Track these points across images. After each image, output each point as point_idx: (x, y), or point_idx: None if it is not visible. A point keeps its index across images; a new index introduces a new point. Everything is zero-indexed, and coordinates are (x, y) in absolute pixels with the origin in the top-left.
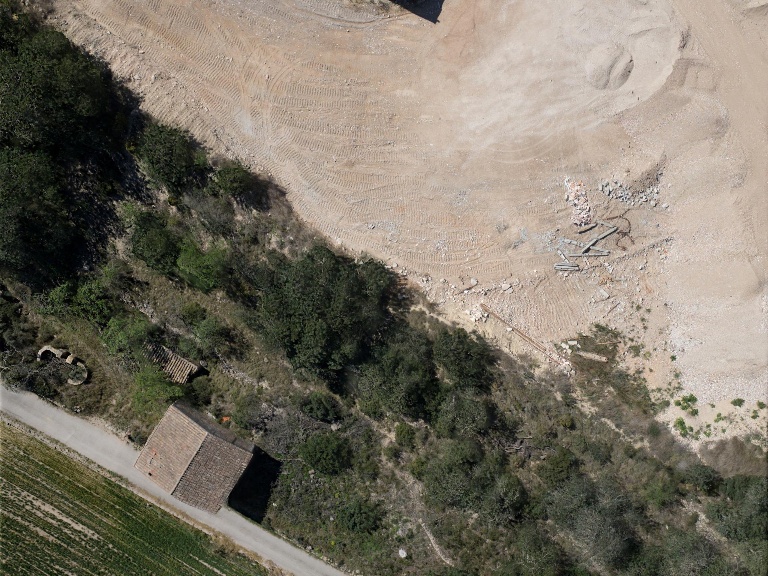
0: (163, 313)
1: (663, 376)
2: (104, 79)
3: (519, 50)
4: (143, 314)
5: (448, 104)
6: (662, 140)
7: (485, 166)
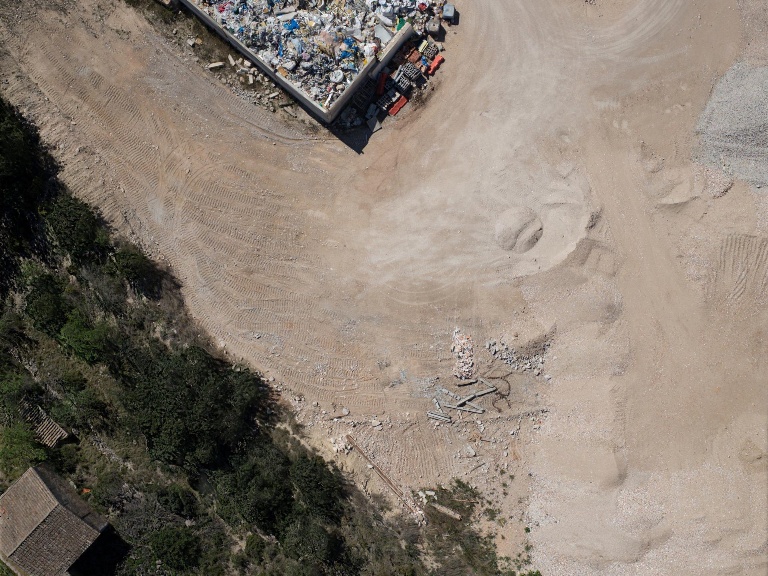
0: (46, 374)
1: (514, 546)
2: (31, 142)
3: (435, 196)
4: (27, 371)
5: (356, 233)
6: (555, 313)
7: (379, 301)
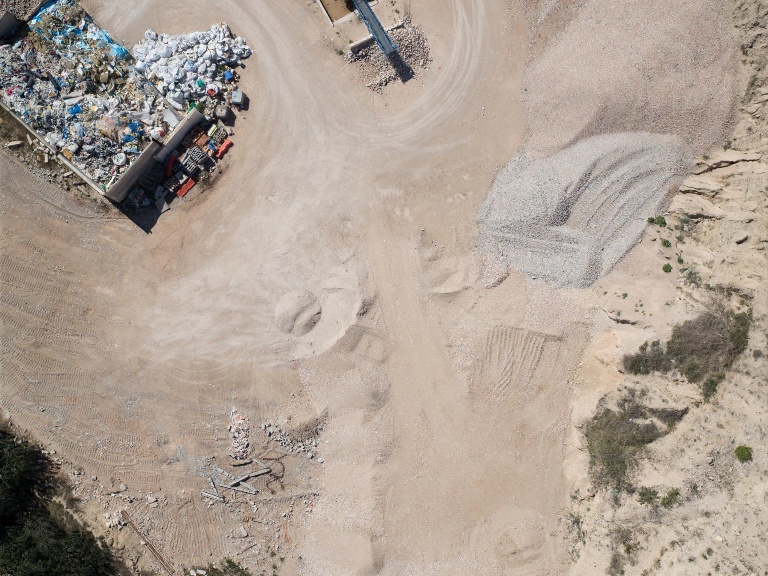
0: None
1: None
2: None
3: (218, 277)
4: None
5: (141, 311)
6: (327, 397)
7: (160, 378)
